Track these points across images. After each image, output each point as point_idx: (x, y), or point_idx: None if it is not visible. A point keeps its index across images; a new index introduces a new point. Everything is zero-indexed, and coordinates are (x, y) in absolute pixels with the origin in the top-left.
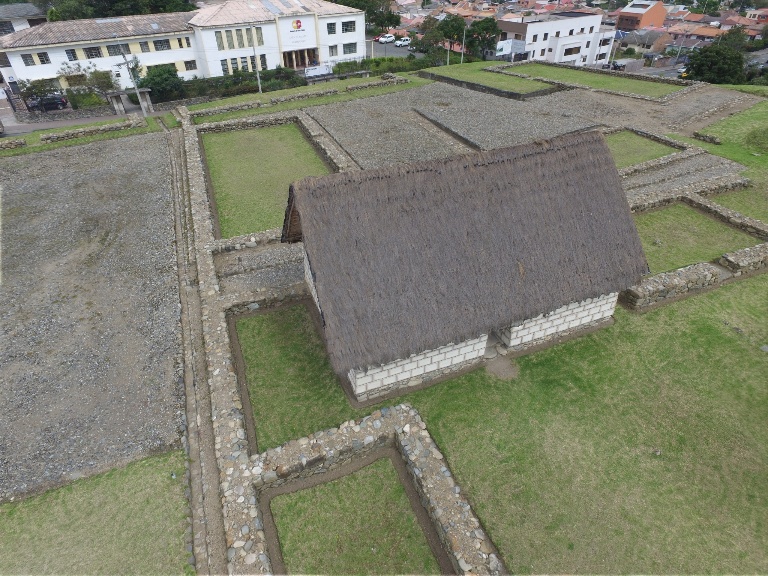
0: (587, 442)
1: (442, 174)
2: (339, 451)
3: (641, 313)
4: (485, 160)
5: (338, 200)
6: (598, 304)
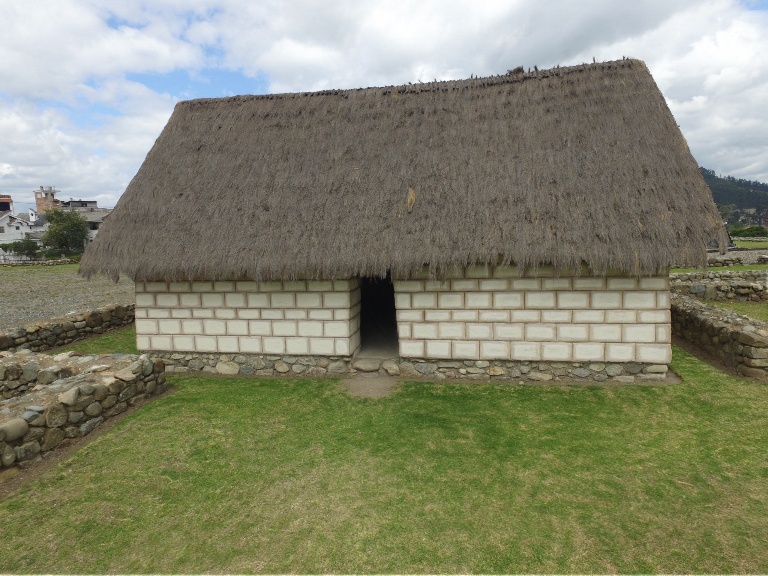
0: (375, 515)
1: (349, 98)
2: (6, 368)
3: (766, 382)
4: (417, 87)
5: (211, 112)
6: (612, 317)
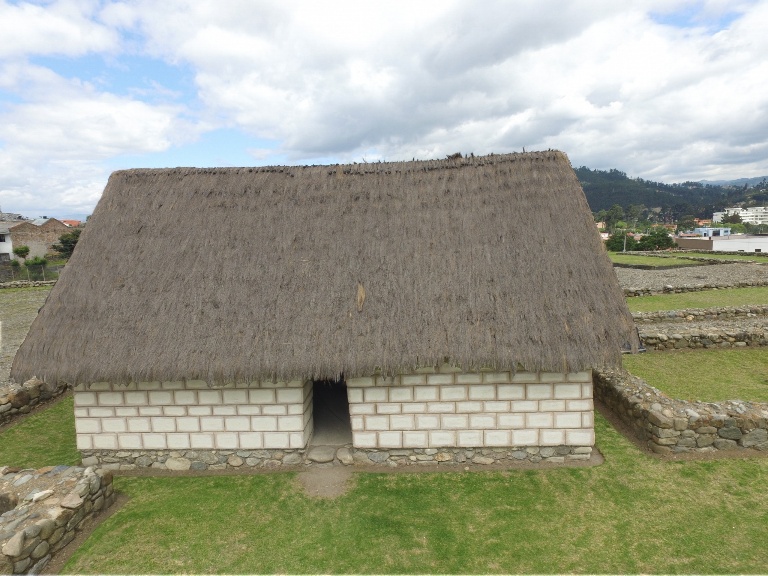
0: None
1: (295, 177)
2: None
3: (671, 460)
4: (362, 168)
5: (149, 186)
6: (544, 406)
